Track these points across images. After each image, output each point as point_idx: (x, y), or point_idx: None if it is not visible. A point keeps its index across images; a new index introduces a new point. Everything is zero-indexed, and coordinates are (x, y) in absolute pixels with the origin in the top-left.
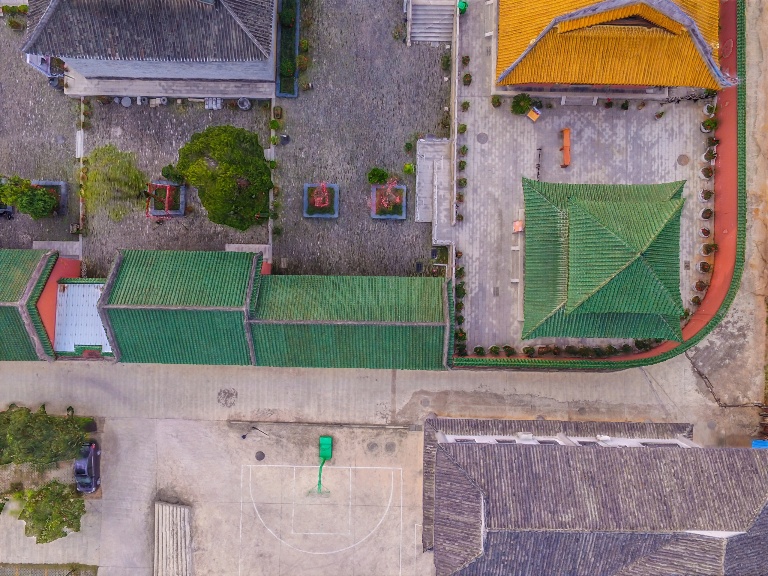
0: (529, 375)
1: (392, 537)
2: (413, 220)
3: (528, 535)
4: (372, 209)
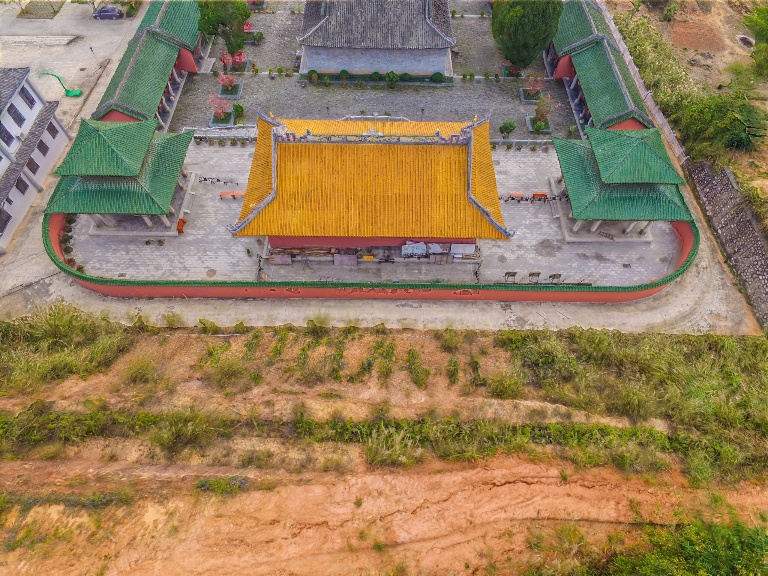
0: None
1: None
2: None
3: None
4: None
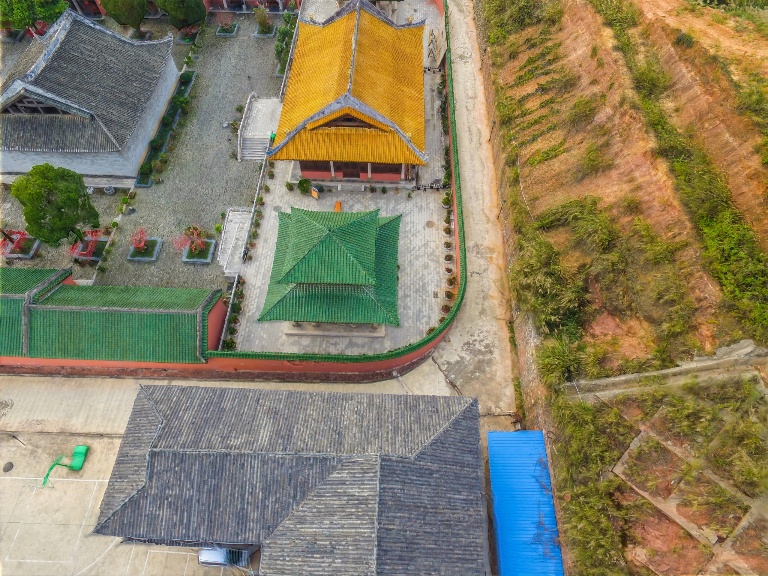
0: (294, 387)
1: (118, 567)
2: (217, 264)
3: (192, 458)
4: (184, 255)
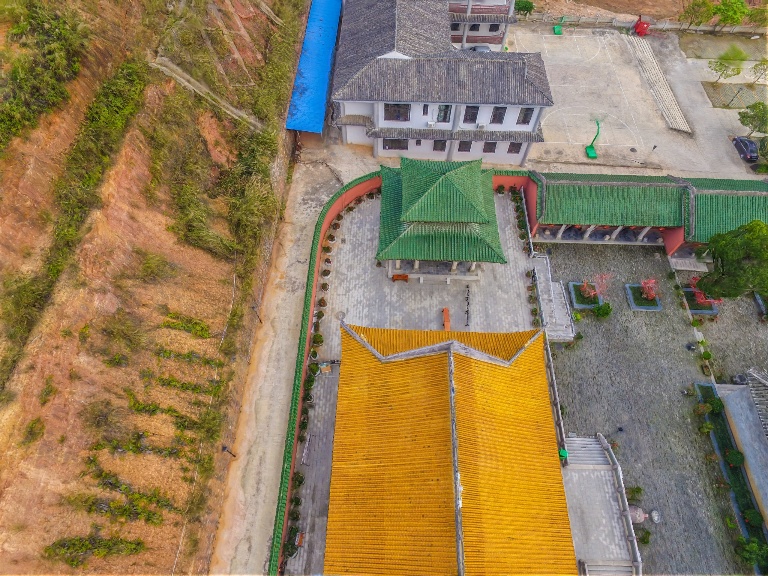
0: None
1: None
2: None
3: None
4: None
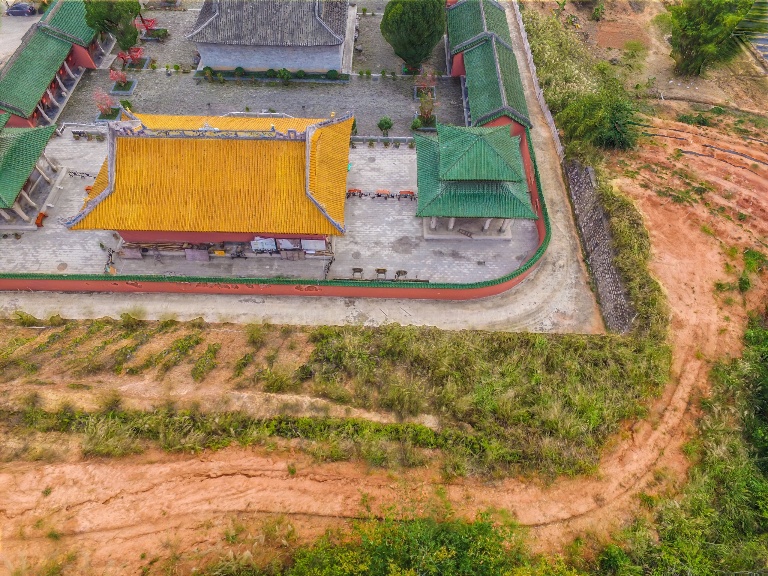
0: None
1: None
2: None
3: None
4: None
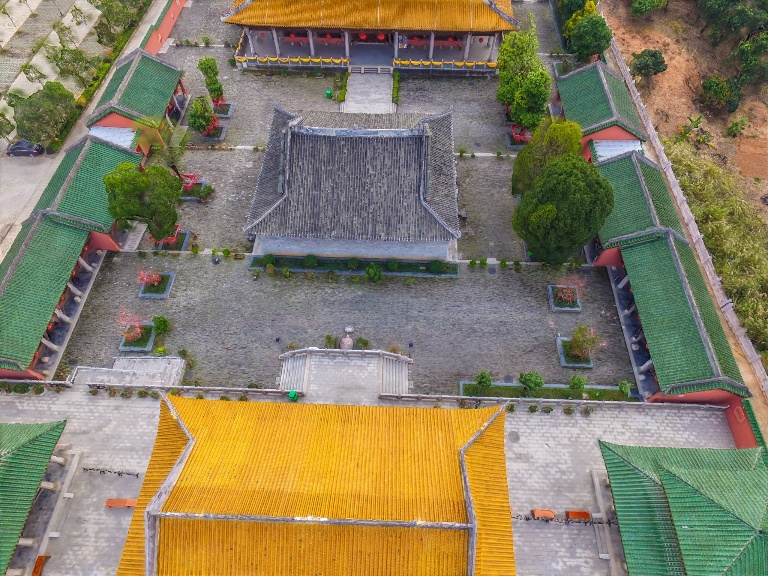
0: None
1: None
2: None
3: None
4: None
